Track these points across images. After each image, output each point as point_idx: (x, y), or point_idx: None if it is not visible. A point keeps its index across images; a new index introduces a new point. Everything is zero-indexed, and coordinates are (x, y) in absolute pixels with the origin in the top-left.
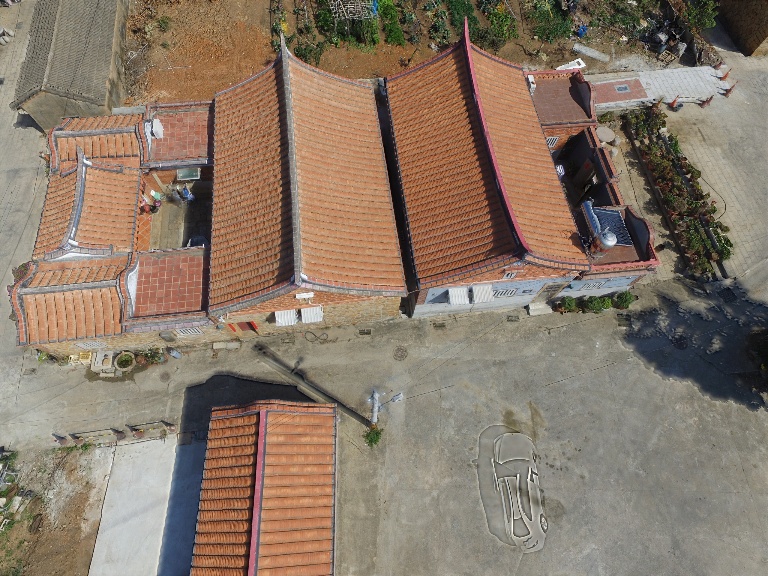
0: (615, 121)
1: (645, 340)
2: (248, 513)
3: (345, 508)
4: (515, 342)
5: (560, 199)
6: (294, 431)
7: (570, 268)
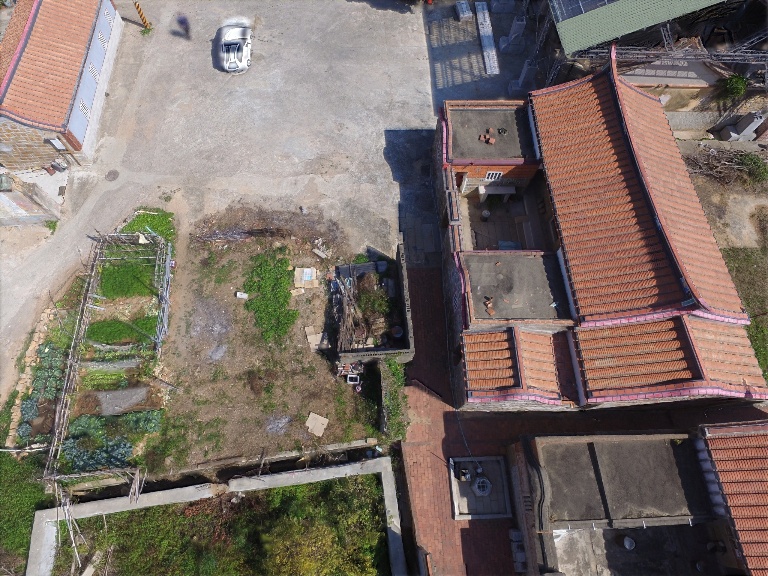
0: None
1: None
2: None
3: (120, 60)
4: None
5: None
6: None
7: None
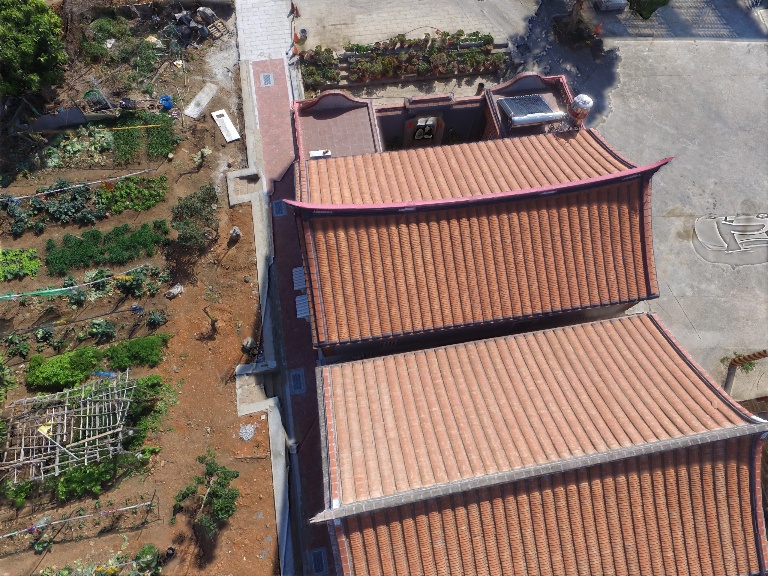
0: None
1: None
2: None
3: None
4: None
5: (515, 143)
6: None
7: None
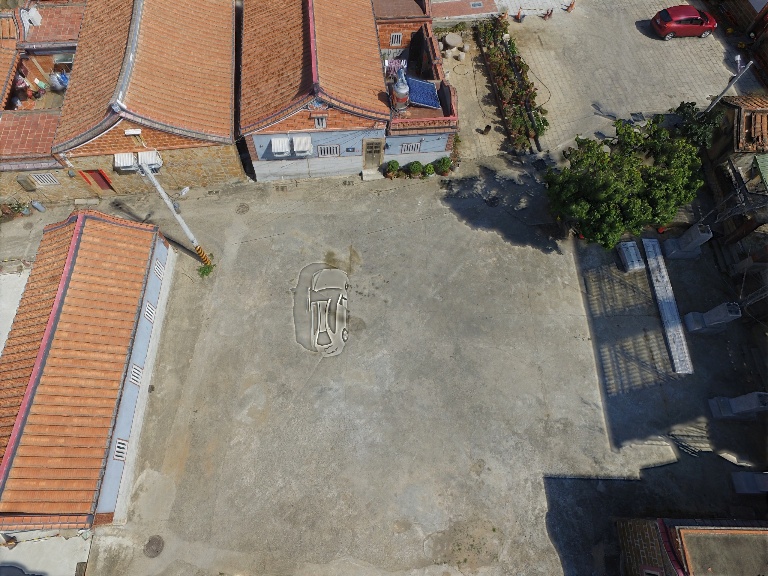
0: (466, 30)
1: (462, 200)
2: None
3: (171, 322)
4: (347, 201)
5: (376, 67)
6: (111, 237)
7: (371, 115)
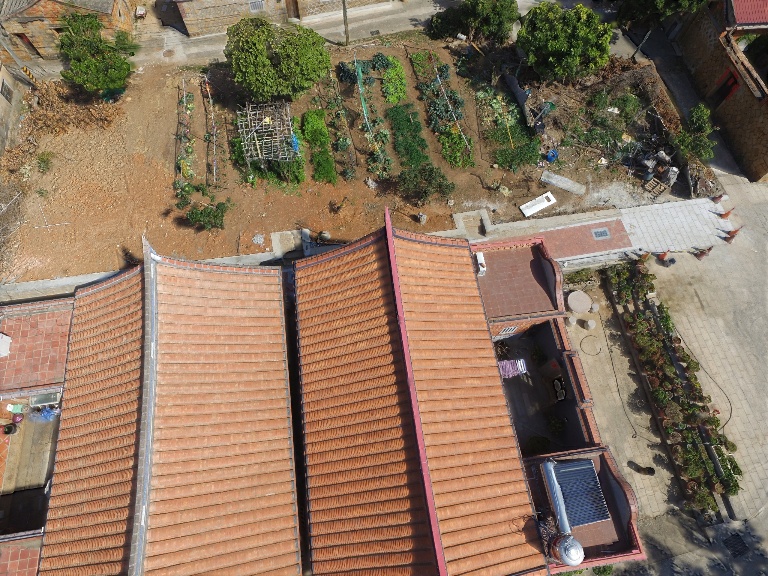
0: (592, 281)
1: None
2: None
3: None
4: None
5: (511, 461)
6: None
7: None
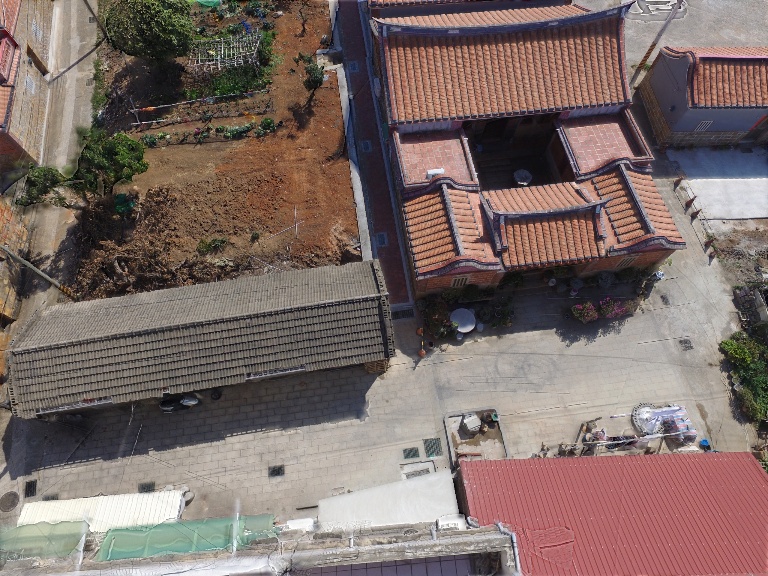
0: None
1: None
2: (756, 66)
3: None
4: None
5: None
6: None
7: None
